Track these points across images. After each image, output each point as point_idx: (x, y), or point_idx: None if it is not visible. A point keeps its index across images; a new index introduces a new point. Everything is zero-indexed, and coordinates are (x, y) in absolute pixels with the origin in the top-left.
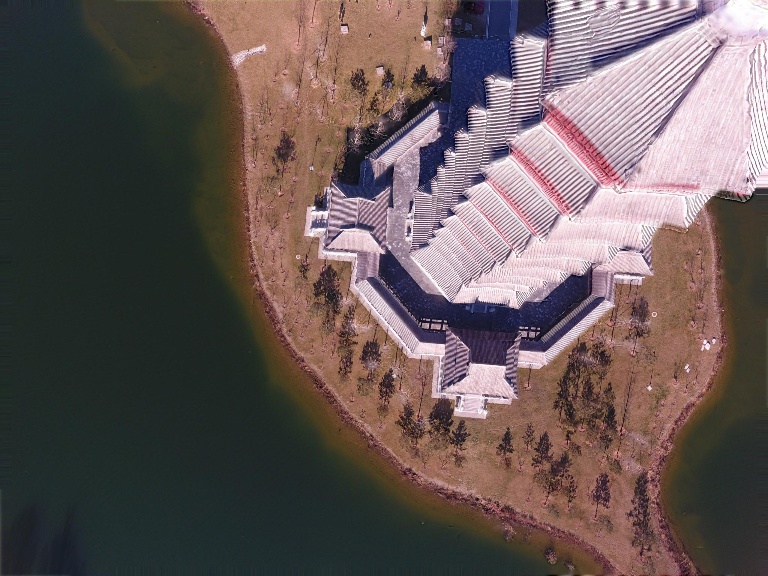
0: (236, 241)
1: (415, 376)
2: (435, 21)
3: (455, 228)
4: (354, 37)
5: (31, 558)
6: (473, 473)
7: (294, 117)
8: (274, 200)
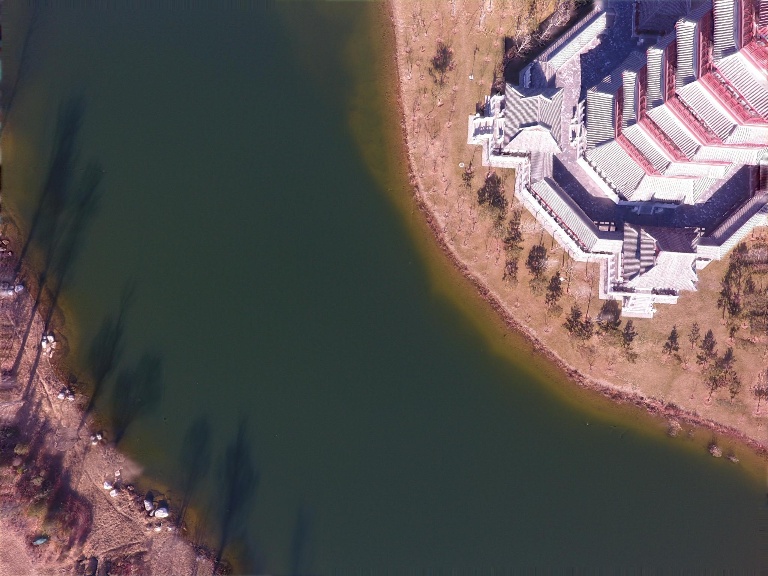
0: (393, 153)
1: (582, 278)
2: None
3: (691, 96)
4: None
5: (205, 468)
6: (639, 372)
7: (450, 27)
8: (433, 110)
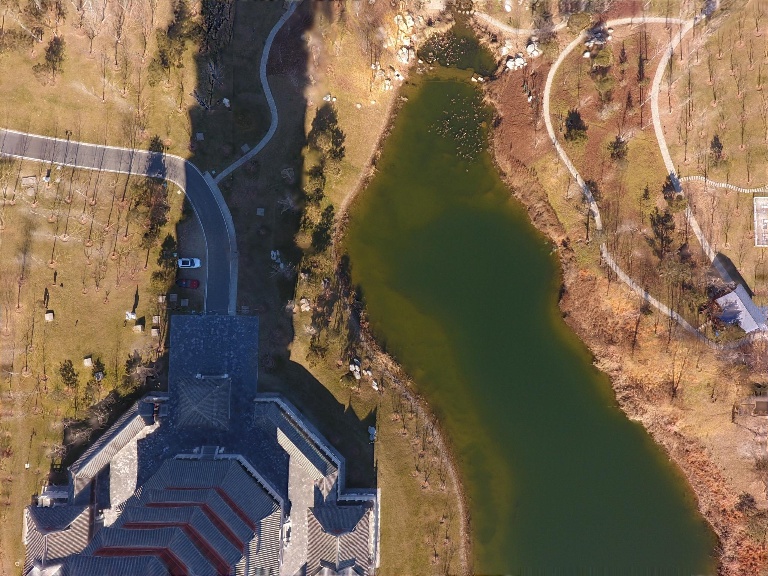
0: None
1: None
2: (147, 300)
3: None
4: (60, 325)
5: None
6: None
7: (8, 408)
8: None
